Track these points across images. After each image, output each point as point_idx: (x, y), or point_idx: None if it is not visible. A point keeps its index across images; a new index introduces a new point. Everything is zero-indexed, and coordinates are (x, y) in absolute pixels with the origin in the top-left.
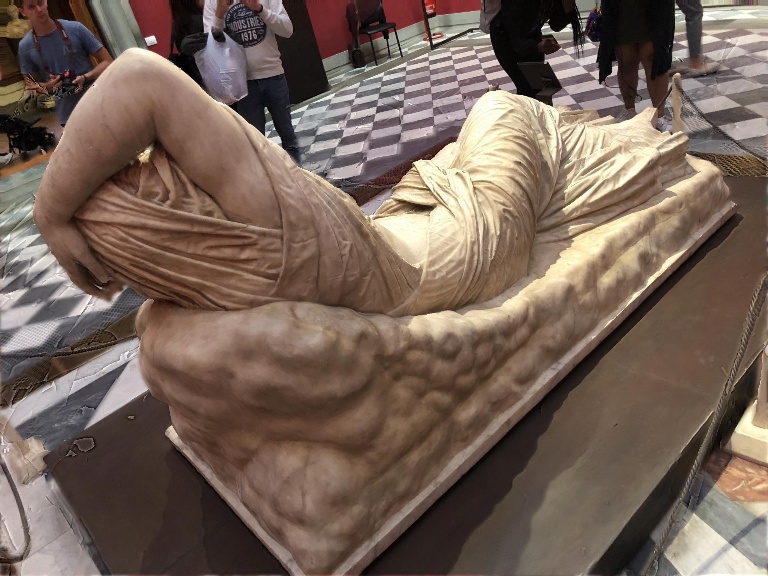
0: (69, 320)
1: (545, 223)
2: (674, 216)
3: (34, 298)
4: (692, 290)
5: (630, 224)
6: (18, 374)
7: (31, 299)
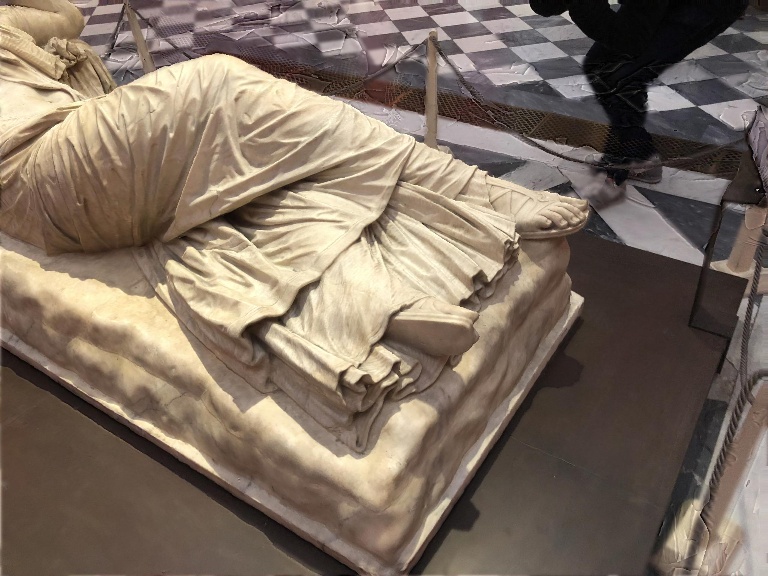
0: (228, 39)
1: (160, 253)
2: (220, 423)
3: (203, 5)
4: (154, 495)
5: (163, 352)
6: (164, 49)
7: (200, 4)
